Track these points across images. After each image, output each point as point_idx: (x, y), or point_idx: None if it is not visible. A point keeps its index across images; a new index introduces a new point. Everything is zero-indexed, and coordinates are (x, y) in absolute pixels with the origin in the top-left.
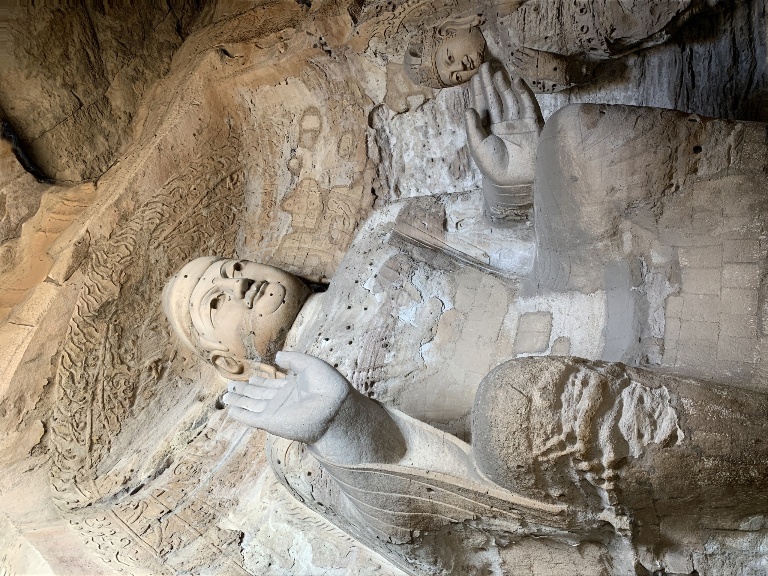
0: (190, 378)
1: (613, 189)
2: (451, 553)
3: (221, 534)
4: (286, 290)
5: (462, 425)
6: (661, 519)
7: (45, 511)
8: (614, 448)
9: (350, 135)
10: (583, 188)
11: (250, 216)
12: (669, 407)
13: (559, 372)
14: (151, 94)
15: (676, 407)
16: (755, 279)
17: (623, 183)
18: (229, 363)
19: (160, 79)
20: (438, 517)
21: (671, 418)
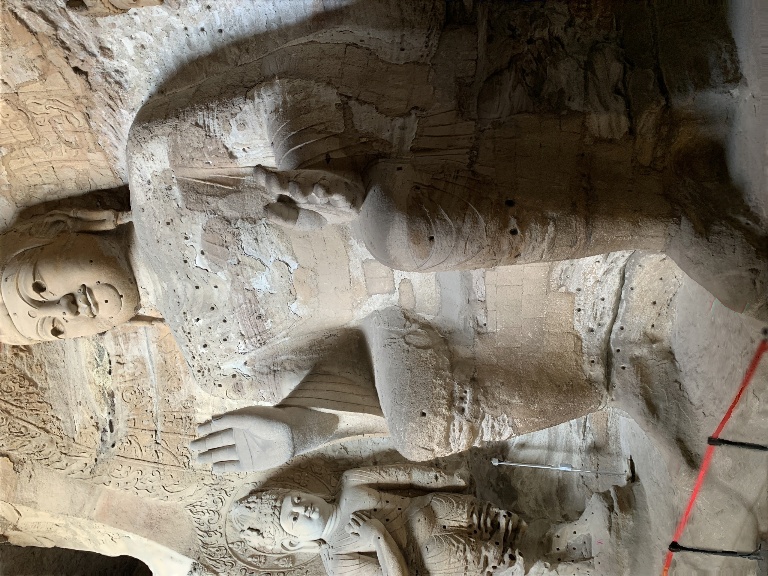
0: None
1: None
2: None
3: None
4: (113, 286)
5: (342, 327)
6: None
7: (78, 489)
8: None
9: None
10: None
11: None
12: None
13: (444, 429)
14: None
15: (512, 426)
16: None
17: None
18: None
19: None
20: None
21: None
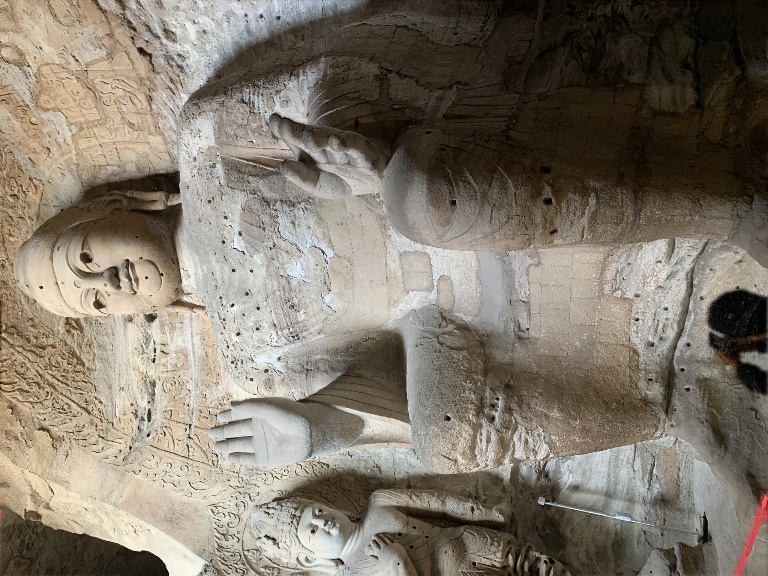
0: None
1: None
2: None
3: None
4: (155, 263)
5: (379, 329)
6: None
7: (109, 474)
8: None
9: None
10: None
11: (12, 135)
12: (544, 443)
13: (470, 437)
14: None
15: (548, 443)
16: (600, 259)
17: None
18: None
19: None
20: None
21: (546, 450)
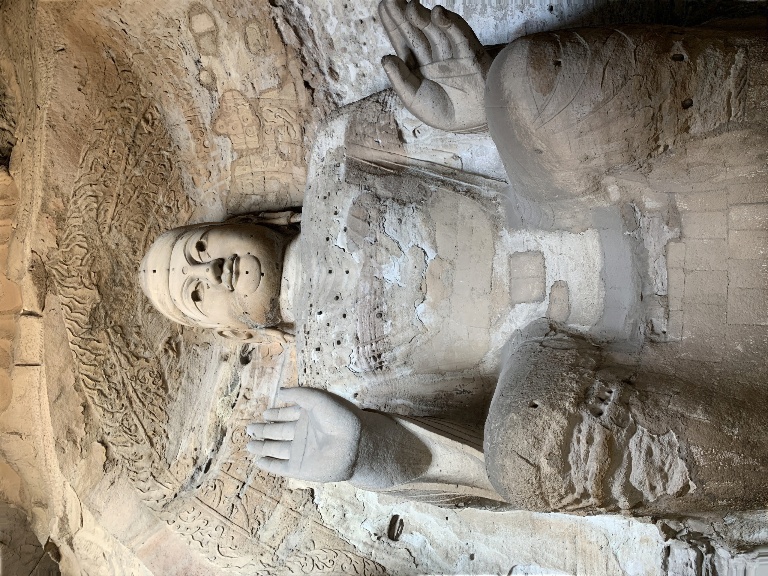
0: (206, 342)
1: (587, 157)
2: None
3: (294, 497)
4: (259, 261)
5: (477, 372)
6: None
7: (143, 517)
8: (628, 499)
9: (254, 24)
10: (551, 159)
11: (186, 153)
12: (679, 459)
13: (562, 431)
14: (3, 37)
15: (686, 458)
16: (767, 219)
17: (598, 151)
18: (236, 333)
19: (1, 11)
20: None
21: (682, 471)
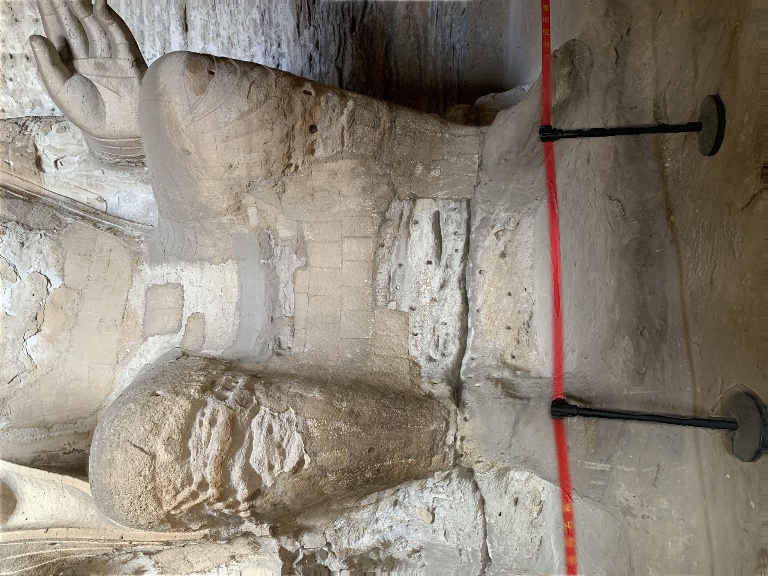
0: None
1: (231, 166)
2: (96, 575)
3: None
4: None
5: (93, 422)
6: (297, 516)
7: None
8: (247, 485)
9: None
10: (198, 163)
11: None
12: (296, 433)
13: (184, 414)
14: None
15: (302, 431)
16: (370, 252)
17: (241, 160)
18: None
19: None
20: (72, 558)
21: (298, 445)
